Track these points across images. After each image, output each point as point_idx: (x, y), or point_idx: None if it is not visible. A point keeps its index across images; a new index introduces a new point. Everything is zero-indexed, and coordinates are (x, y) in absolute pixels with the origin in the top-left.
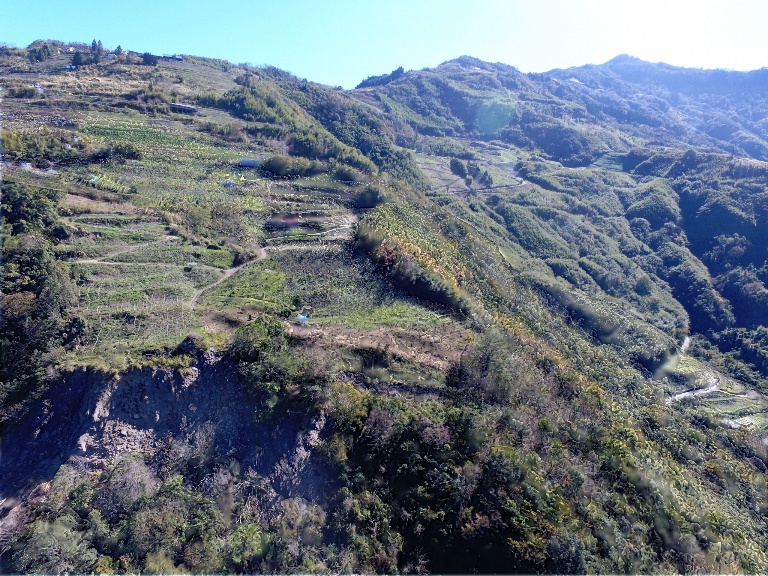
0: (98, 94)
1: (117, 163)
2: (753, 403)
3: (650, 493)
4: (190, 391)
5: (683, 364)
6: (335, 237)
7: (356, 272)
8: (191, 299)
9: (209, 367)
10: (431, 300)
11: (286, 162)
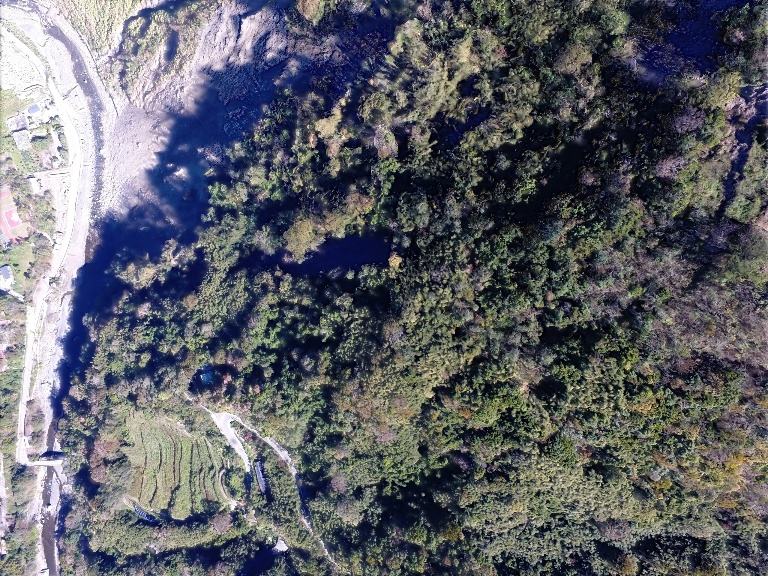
0: None
1: None
2: None
3: None
4: None
5: None
6: None
7: None
8: None
9: None
10: None
11: None
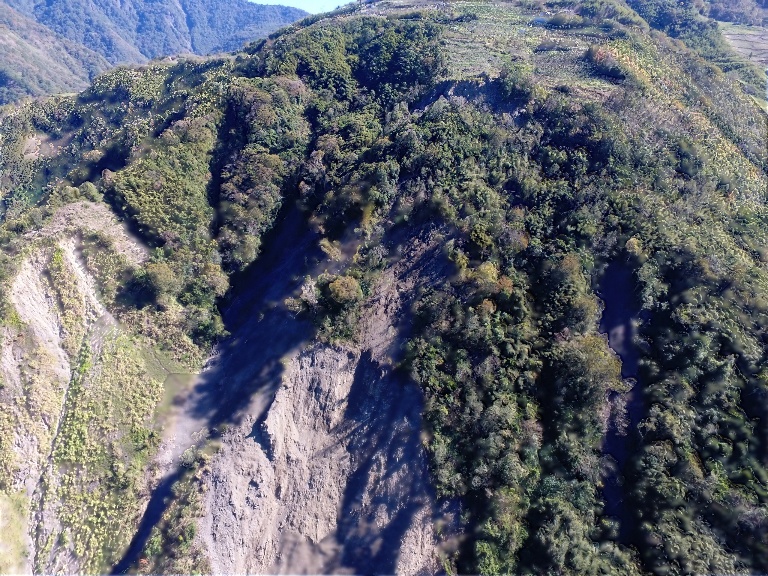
0: None
1: (467, 22)
2: None
3: None
4: (481, 88)
5: None
6: None
7: (575, 64)
8: None
9: (489, 82)
10: (616, 78)
11: (564, 18)
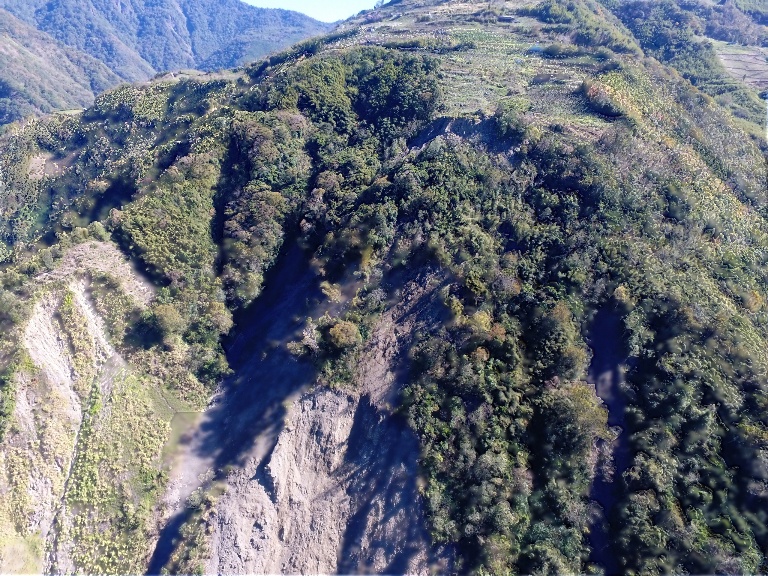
0: (459, 15)
1: (464, 51)
2: None
3: None
4: (477, 126)
5: None
6: None
7: (569, 100)
8: None
9: (485, 120)
10: (608, 116)
11: (559, 47)
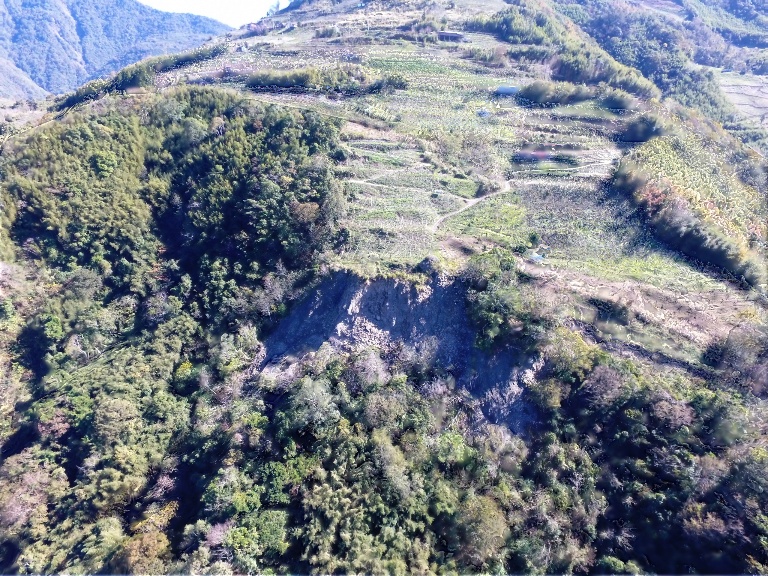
0: (380, 28)
1: (388, 93)
2: None
3: None
4: (422, 306)
5: None
6: (589, 174)
7: (608, 215)
8: (434, 224)
9: (441, 288)
10: (701, 259)
11: (547, 88)
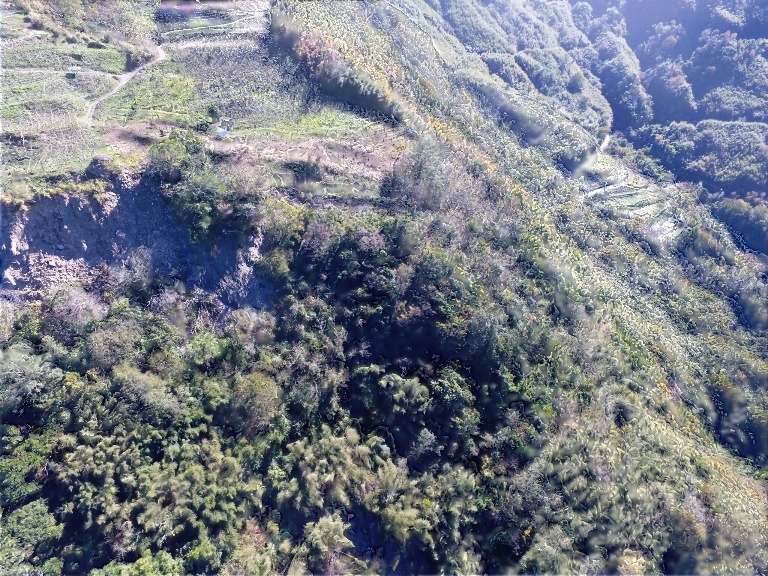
0: None
1: None
2: (652, 195)
3: (555, 277)
4: (113, 217)
5: (600, 162)
6: (245, 29)
7: (276, 74)
8: (85, 113)
9: (128, 191)
10: (361, 105)
11: None
